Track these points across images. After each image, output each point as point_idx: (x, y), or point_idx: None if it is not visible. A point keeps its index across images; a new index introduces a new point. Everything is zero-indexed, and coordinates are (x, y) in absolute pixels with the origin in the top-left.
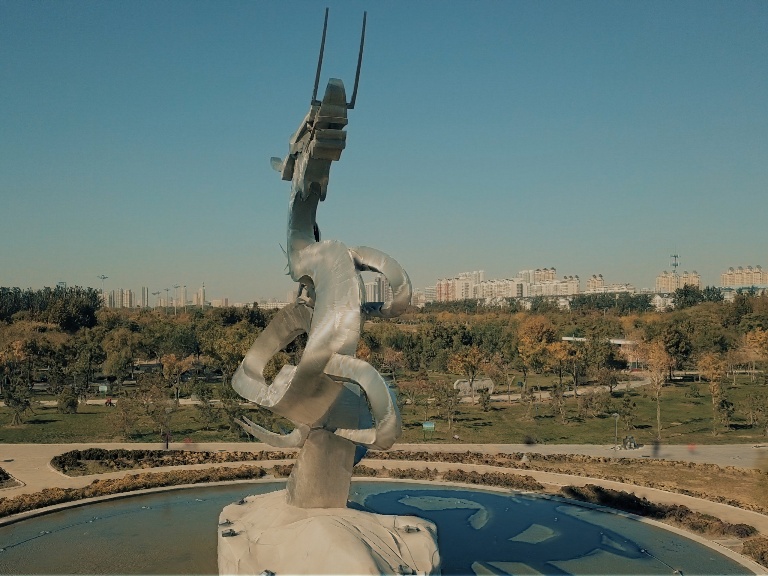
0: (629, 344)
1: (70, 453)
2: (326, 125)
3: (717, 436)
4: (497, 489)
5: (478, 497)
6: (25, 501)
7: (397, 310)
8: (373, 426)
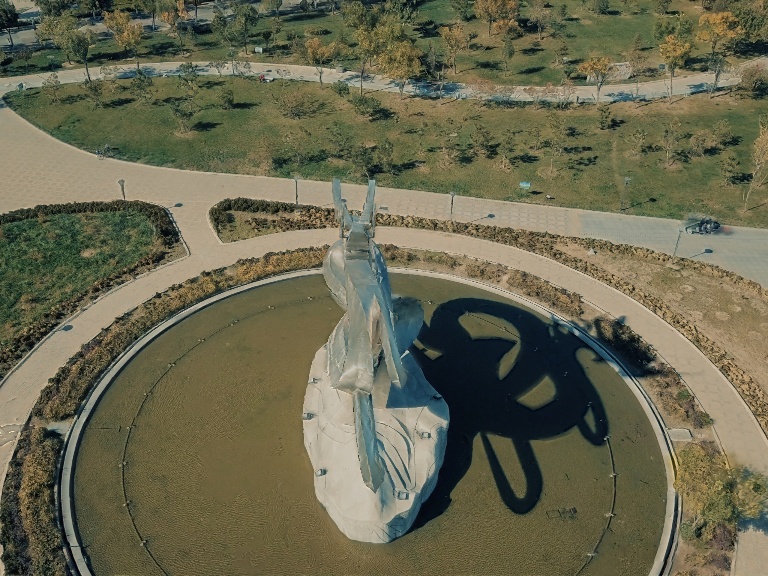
0: None
1: (223, 205)
2: None
3: None
4: (542, 312)
5: (523, 321)
6: (188, 296)
7: None
8: (483, 159)
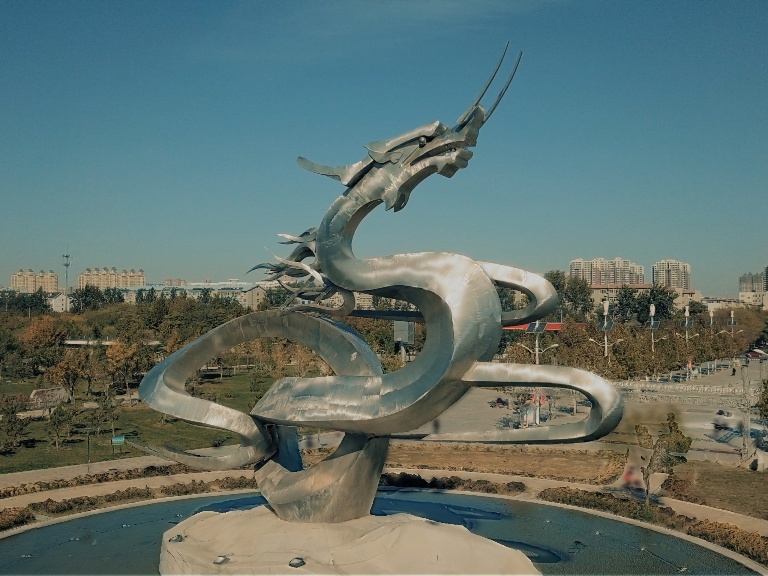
0: (151, 345)
1: None
2: (463, 145)
3: None
4: None
5: None
6: None
7: (527, 320)
8: (25, 449)
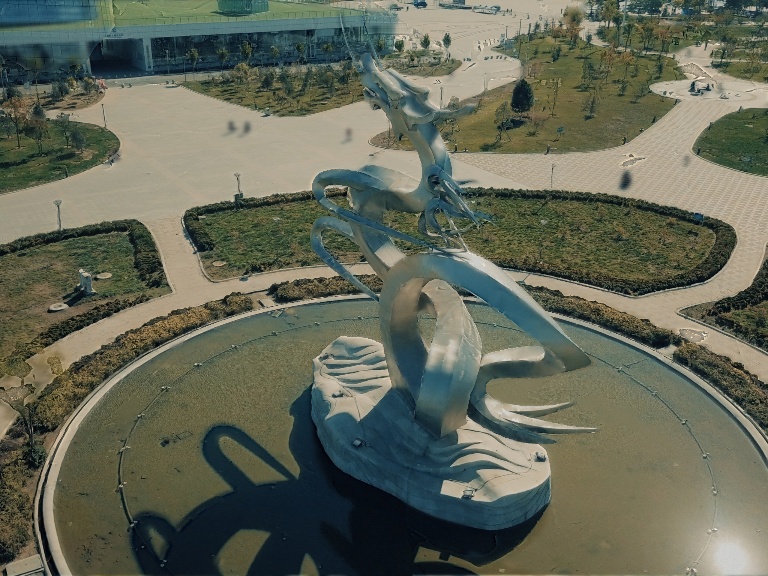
0: None
1: None
2: None
3: None
4: None
5: None
6: None
7: None
8: None
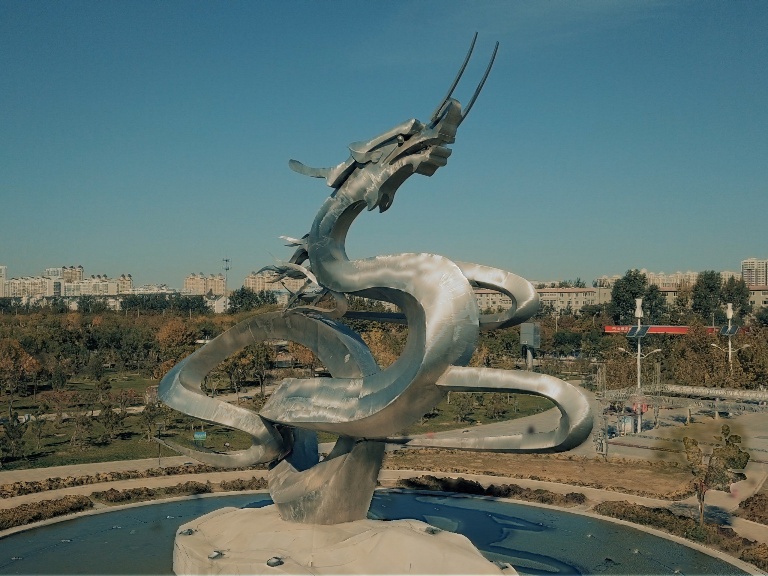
0: (274, 345)
1: None
2: (438, 142)
3: (425, 425)
4: None
5: None
6: None
7: (510, 323)
8: (120, 441)
